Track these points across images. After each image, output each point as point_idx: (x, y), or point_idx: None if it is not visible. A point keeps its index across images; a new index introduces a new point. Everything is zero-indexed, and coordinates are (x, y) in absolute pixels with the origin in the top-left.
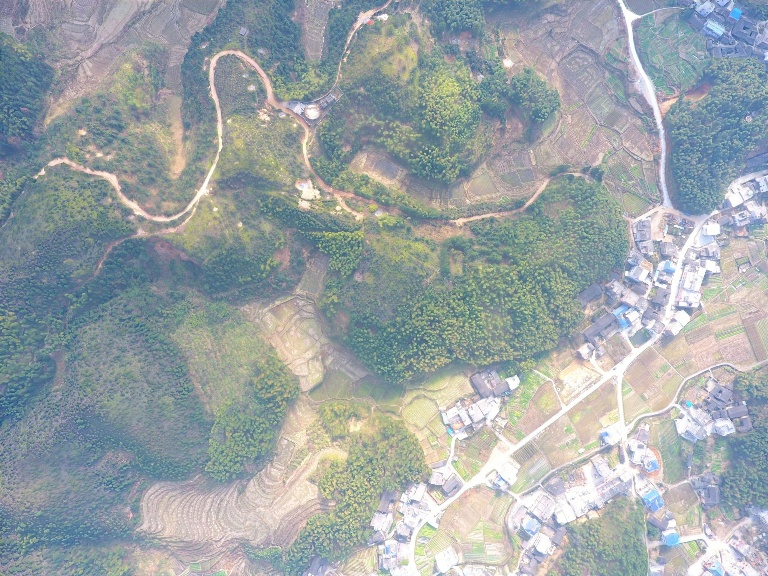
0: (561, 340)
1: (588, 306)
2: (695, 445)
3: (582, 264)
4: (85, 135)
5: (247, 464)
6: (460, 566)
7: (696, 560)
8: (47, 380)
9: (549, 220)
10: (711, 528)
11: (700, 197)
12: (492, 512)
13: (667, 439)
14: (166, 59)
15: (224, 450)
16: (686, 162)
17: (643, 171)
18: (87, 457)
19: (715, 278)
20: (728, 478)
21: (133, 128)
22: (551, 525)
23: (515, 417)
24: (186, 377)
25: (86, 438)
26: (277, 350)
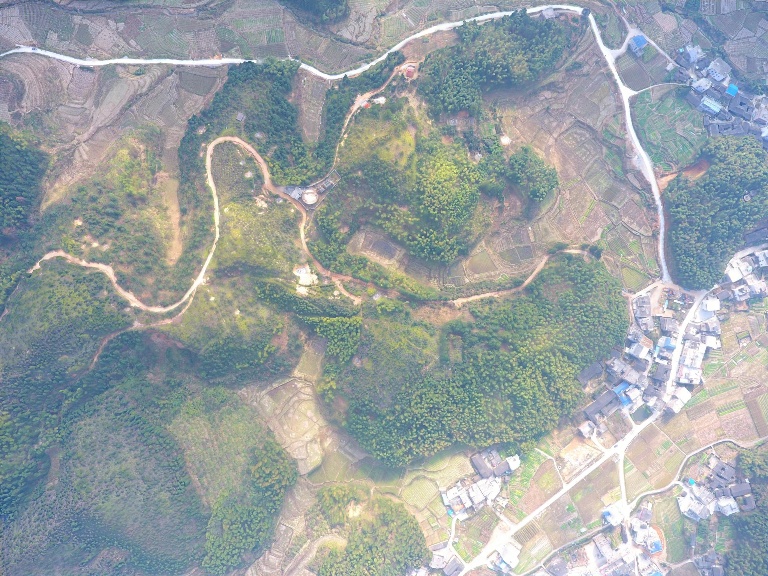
0: (562, 419)
1: (588, 384)
2: (698, 524)
3: (582, 347)
4: (81, 226)
5: (245, 555)
6: None
7: None
8: (41, 477)
9: (548, 304)
10: None
11: (699, 275)
12: None
13: (670, 517)
14: (163, 141)
15: (221, 544)
16: (685, 241)
17: (642, 246)
18: (81, 557)
19: (716, 353)
20: (732, 559)
21: (129, 215)
22: None
23: (516, 496)
24: (182, 470)
25: (80, 538)
26: (275, 433)
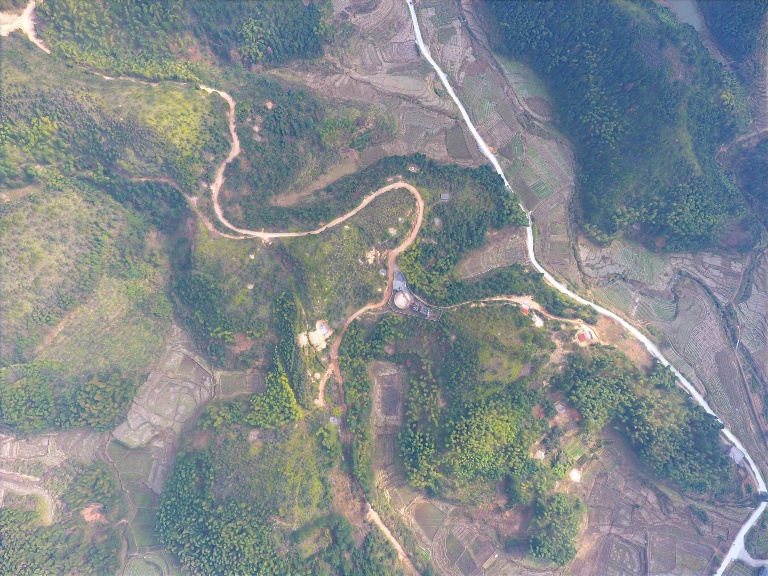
0: None
1: None
2: None
3: None
4: (268, 109)
5: None
6: None
7: None
8: (9, 185)
9: None
10: None
11: None
12: None
13: None
14: (387, 140)
15: None
16: None
17: None
18: None
19: None
20: None
21: (301, 144)
22: None
23: None
24: (63, 312)
25: None
26: (146, 383)
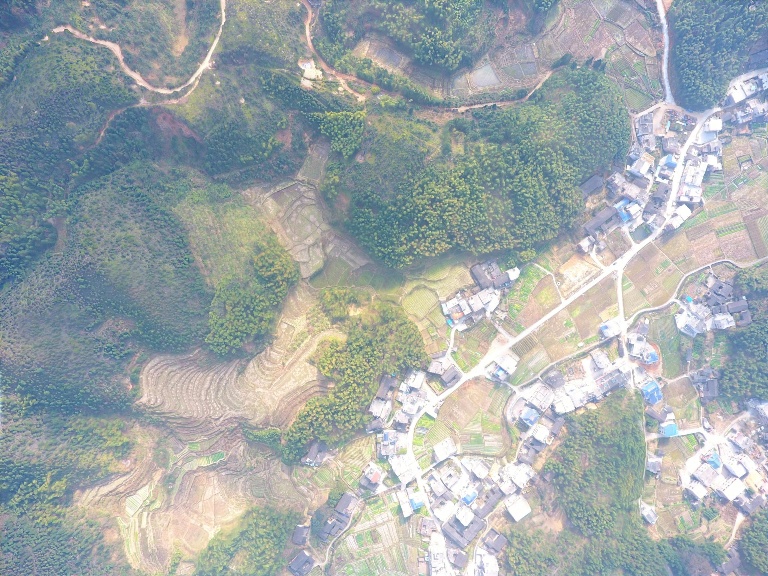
0: (562, 231)
1: (589, 199)
2: (694, 340)
3: (584, 149)
4: (88, 6)
5: (247, 341)
6: (458, 457)
7: (694, 453)
8: (48, 246)
9: (551, 103)
10: (709, 422)
11: (703, 89)
12: (491, 404)
13: (667, 334)
14: None
15: (224, 323)
16: (689, 52)
17: (646, 67)
18: (87, 321)
19: (717, 175)
20: (727, 370)
21: (136, 5)
22: (550, 416)
23: (515, 310)
24: (187, 248)
25: (87, 301)
26: (278, 235)
